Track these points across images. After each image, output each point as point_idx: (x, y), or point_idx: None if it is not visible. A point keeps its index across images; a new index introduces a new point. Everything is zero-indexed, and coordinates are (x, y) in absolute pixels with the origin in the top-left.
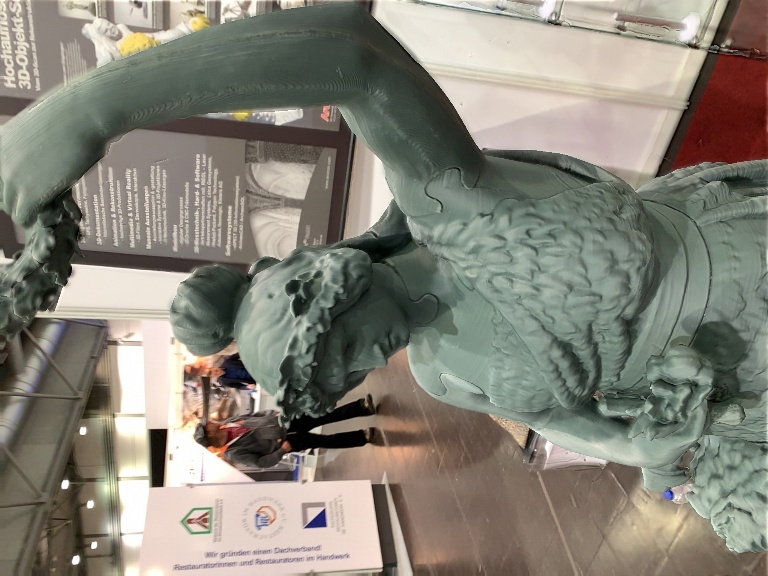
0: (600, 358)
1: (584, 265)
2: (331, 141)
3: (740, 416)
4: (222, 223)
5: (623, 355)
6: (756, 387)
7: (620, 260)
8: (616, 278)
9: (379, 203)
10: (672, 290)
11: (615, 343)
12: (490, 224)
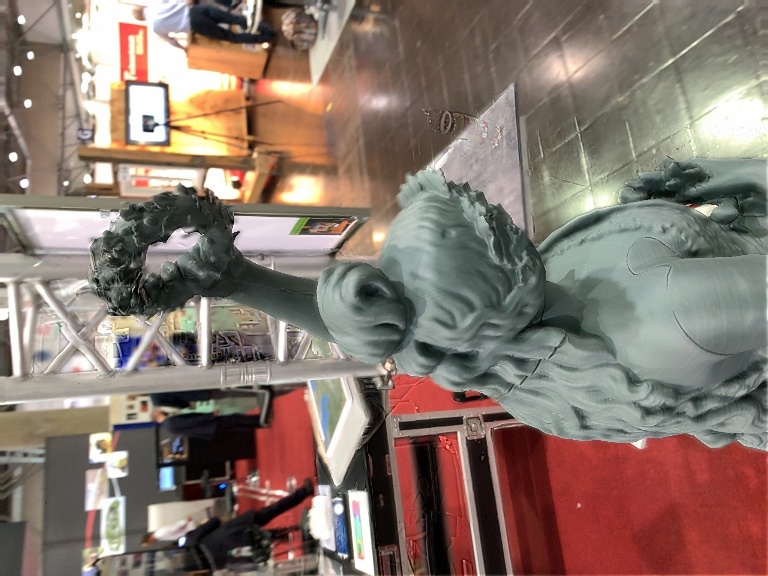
0: None
1: None
2: None
3: None
4: None
5: None
6: None
7: None
8: None
9: None
10: None
11: None
12: None
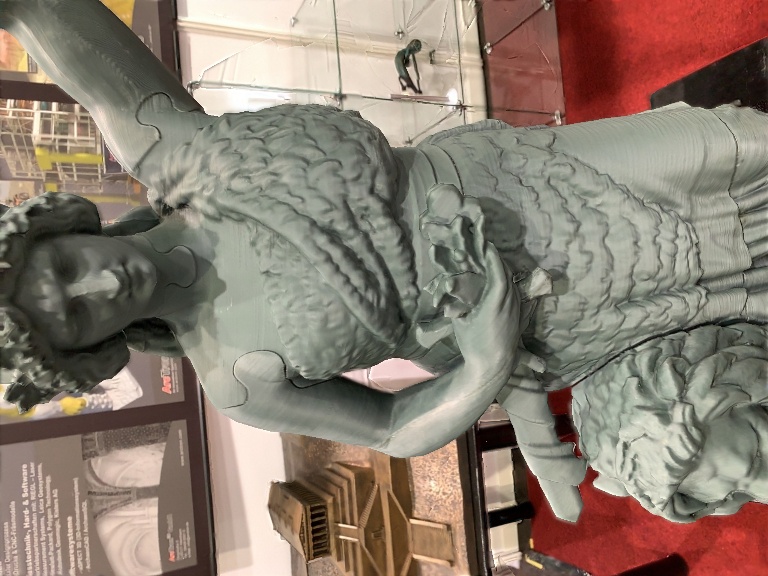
0: (382, 258)
1: (312, 138)
2: (178, 413)
3: (545, 274)
4: (61, 541)
5: (402, 247)
6: (554, 262)
7: (347, 132)
8: (348, 144)
9: (247, 471)
10: (423, 179)
11: (384, 227)
12: (211, 132)
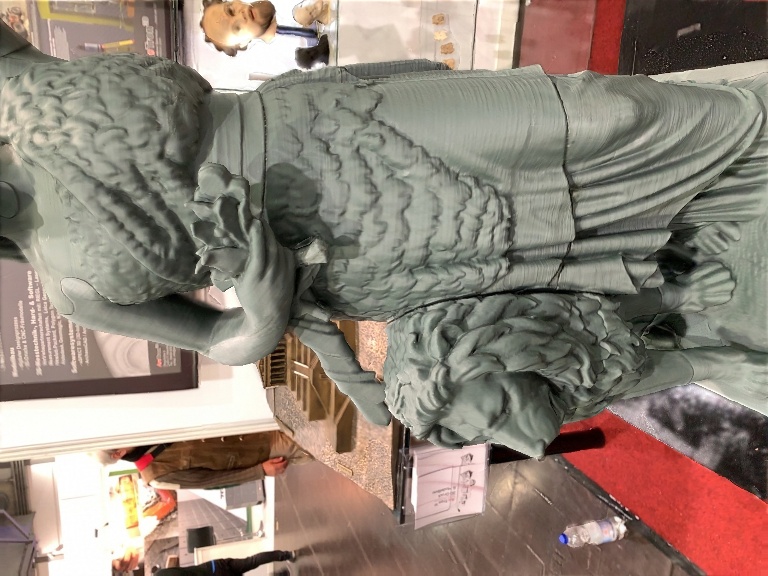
0: (176, 215)
1: (103, 103)
2: None
3: (319, 247)
4: (63, 338)
5: None
6: (346, 230)
7: (141, 97)
8: (137, 111)
9: (233, 300)
10: (228, 139)
11: (174, 189)
12: (16, 84)
